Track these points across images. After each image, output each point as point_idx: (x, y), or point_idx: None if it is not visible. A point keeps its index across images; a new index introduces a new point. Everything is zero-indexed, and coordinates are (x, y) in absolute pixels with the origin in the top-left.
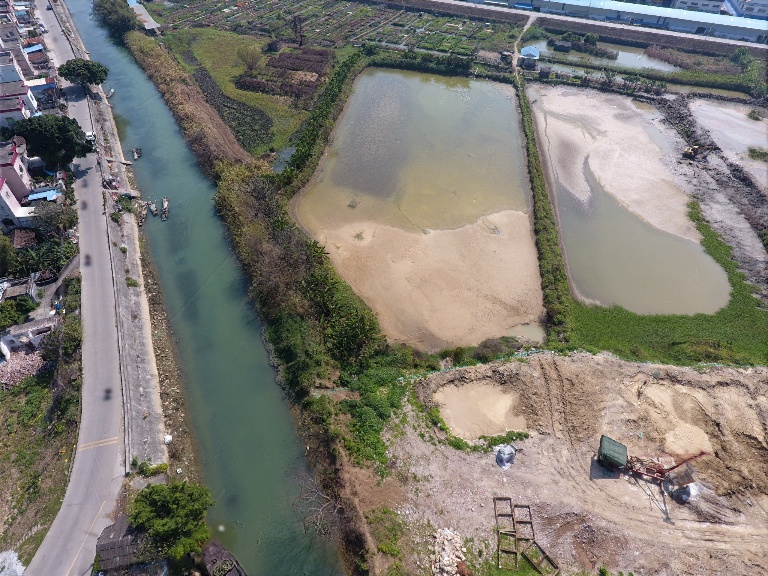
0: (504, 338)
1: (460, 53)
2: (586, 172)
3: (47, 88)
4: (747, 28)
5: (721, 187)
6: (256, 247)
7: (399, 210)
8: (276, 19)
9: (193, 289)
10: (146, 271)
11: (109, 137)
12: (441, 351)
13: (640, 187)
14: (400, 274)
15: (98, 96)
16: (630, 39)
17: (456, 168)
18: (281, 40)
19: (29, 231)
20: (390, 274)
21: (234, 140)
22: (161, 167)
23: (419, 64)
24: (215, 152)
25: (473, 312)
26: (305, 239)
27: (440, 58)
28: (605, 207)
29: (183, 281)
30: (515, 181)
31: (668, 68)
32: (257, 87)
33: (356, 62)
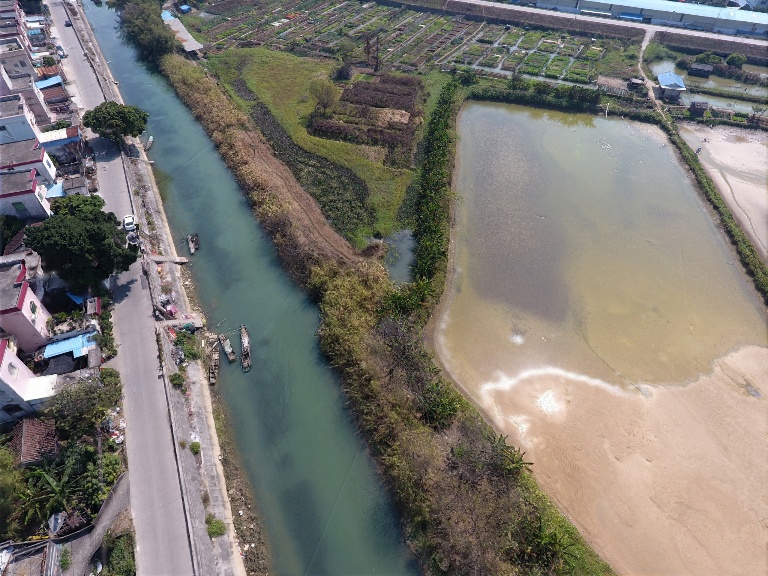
0: None
1: (575, 80)
2: None
3: (68, 143)
4: None
5: None
6: (420, 462)
7: (588, 346)
8: (337, 35)
9: (313, 529)
10: (233, 488)
11: (154, 218)
12: None
13: None
14: (638, 488)
15: (134, 149)
16: None
17: (640, 265)
18: (350, 63)
19: (46, 418)
20: (622, 488)
21: (322, 219)
22: (229, 266)
23: (532, 97)
24: (305, 246)
25: None
26: (476, 420)
27: (560, 90)
28: None
29: (294, 509)
30: (734, 288)
31: None
32: (337, 133)
33: (454, 95)
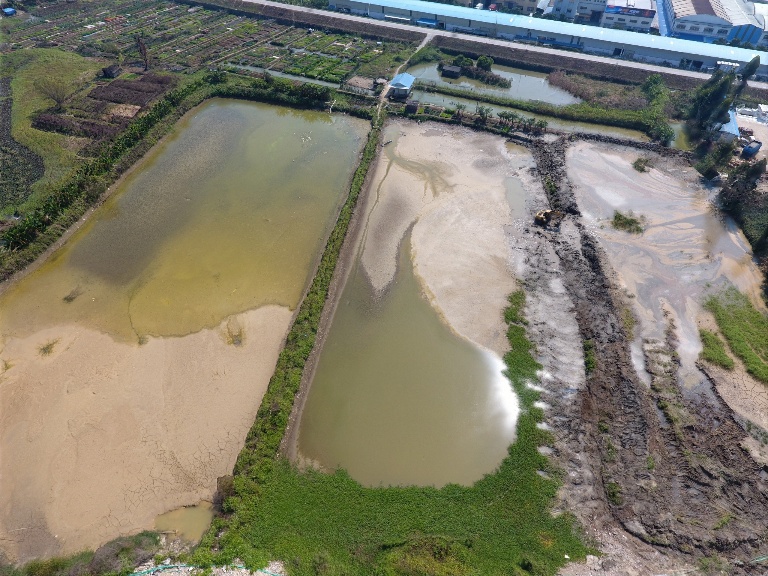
0: (142, 536)
1: (328, 80)
2: (402, 245)
3: None
4: (668, 50)
5: (563, 269)
6: None
7: (127, 305)
8: (139, 37)
9: None
10: None
11: None
12: (35, 562)
13: (460, 268)
14: (64, 414)
15: None
16: (533, 63)
17: (239, 239)
18: (127, 63)
19: None
20: (51, 414)
21: None
22: None
23: (269, 95)
24: None
25: (127, 484)
26: None
27: (292, 88)
28: (402, 299)
29: None
30: (304, 259)
31: (566, 99)
32: (54, 125)
33: (193, 92)
